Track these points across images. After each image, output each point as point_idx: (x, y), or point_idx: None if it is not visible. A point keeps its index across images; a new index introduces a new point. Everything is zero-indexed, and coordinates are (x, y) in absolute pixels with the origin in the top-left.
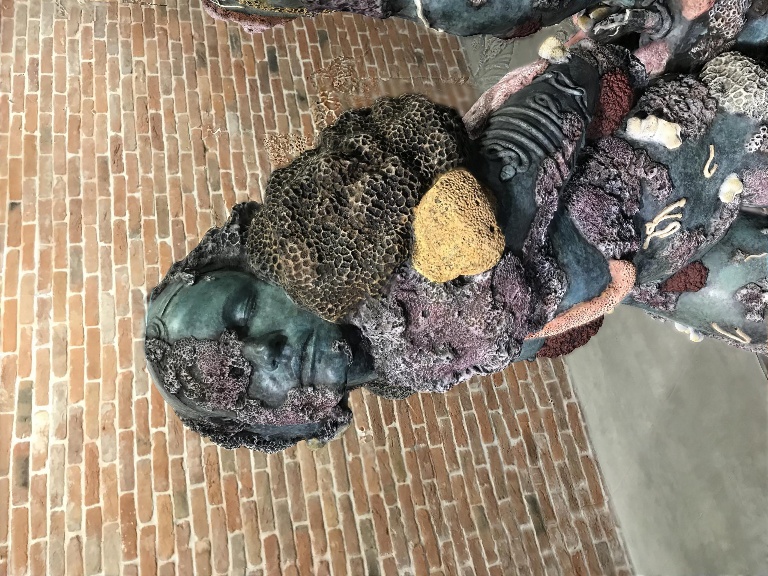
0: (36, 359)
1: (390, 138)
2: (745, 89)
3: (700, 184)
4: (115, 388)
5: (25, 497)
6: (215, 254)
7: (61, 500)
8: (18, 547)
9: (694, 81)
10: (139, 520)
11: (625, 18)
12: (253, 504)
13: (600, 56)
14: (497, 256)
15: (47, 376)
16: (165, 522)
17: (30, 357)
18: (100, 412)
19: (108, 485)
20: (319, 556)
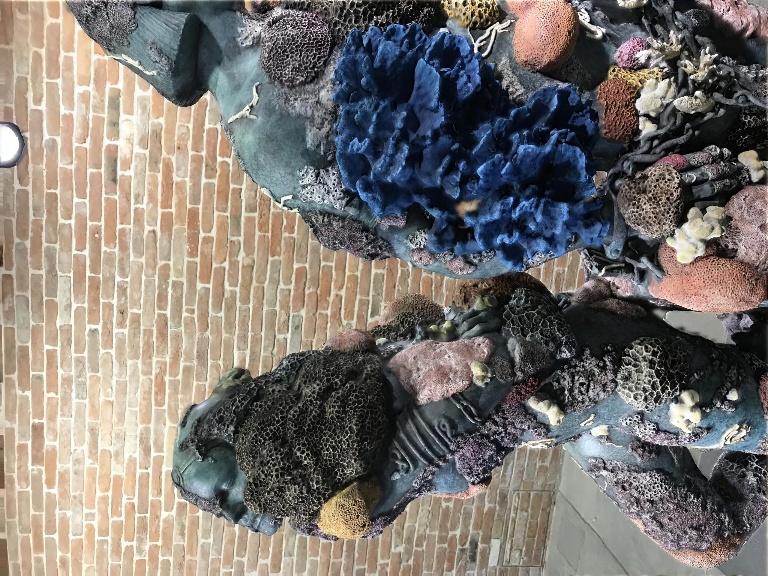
0: (123, 68)
1: (323, 455)
2: (635, 395)
3: (575, 428)
4: (191, 113)
5: (114, 191)
6: (218, 436)
7: (142, 199)
8: (109, 228)
9: (610, 364)
10: (202, 230)
11: (599, 275)
12: (293, 240)
13: (519, 373)
14: (363, 535)
15: (132, 87)
16: (222, 236)
17: (118, 65)
18: (176, 132)
19: (179, 197)
20: (336, 290)
